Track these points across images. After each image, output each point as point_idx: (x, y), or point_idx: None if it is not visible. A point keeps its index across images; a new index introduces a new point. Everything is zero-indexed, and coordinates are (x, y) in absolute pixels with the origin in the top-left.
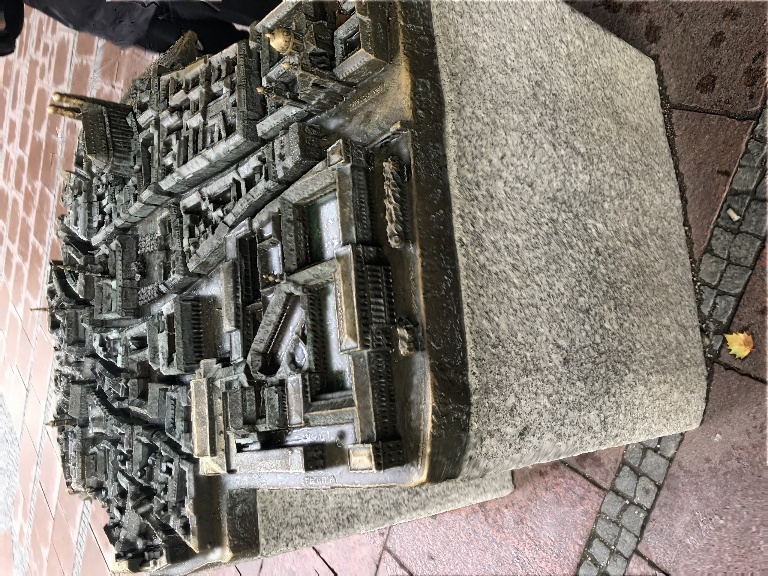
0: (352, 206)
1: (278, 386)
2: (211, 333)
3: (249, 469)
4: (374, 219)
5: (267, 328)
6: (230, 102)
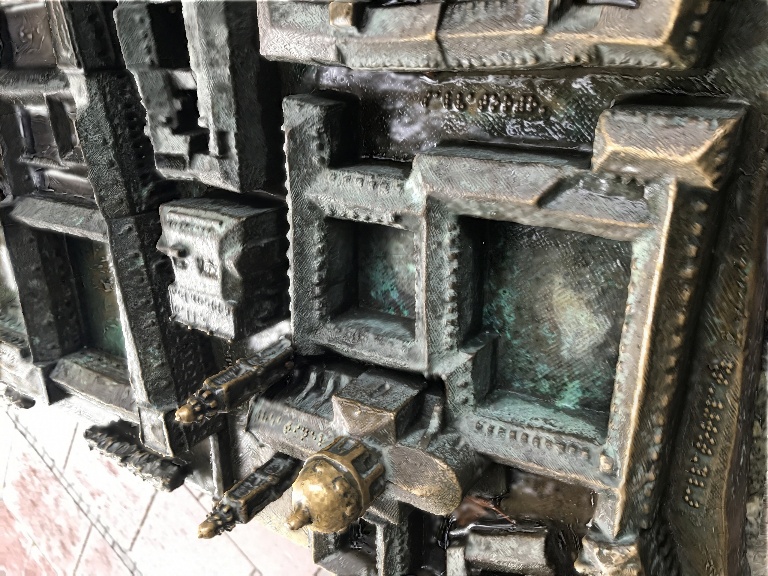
0: None
1: None
2: None
3: None
4: None
5: None
6: None
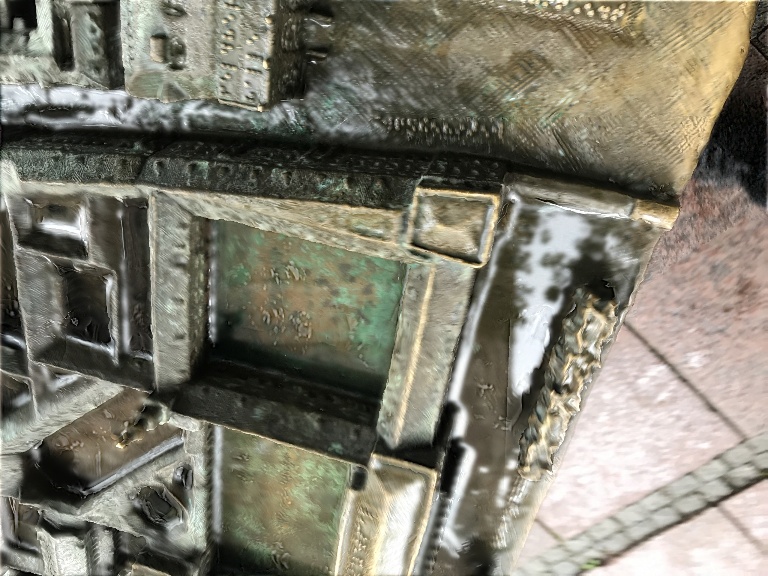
0: (449, 365)
1: (85, 534)
2: None
3: None
4: (457, 354)
5: (49, 428)
6: None
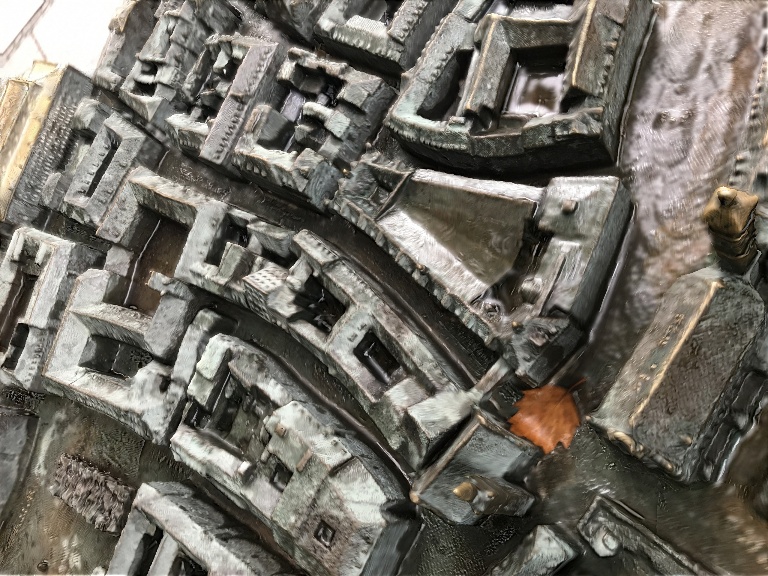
0: None
1: None
2: None
3: (4, 79)
4: None
5: None
6: None
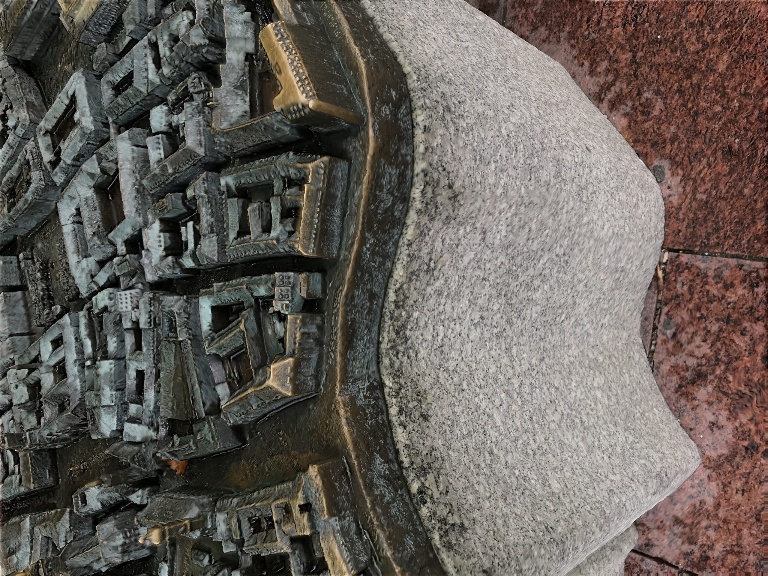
0: None
1: None
2: None
3: None
4: None
5: None
6: None
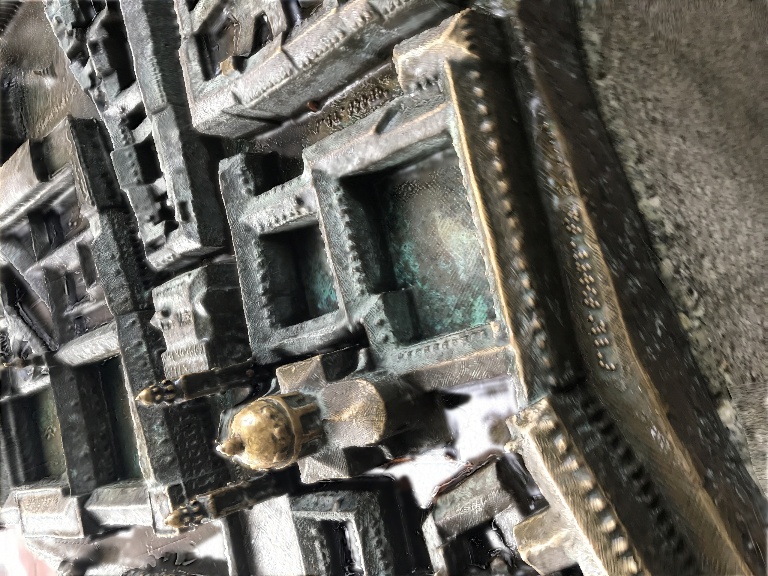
0: None
1: None
2: (28, 36)
3: None
4: None
5: None
6: (264, 1)
